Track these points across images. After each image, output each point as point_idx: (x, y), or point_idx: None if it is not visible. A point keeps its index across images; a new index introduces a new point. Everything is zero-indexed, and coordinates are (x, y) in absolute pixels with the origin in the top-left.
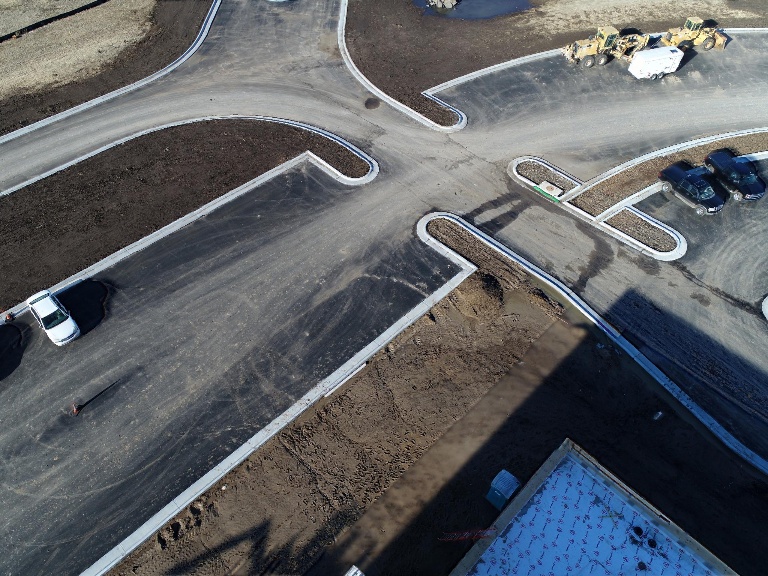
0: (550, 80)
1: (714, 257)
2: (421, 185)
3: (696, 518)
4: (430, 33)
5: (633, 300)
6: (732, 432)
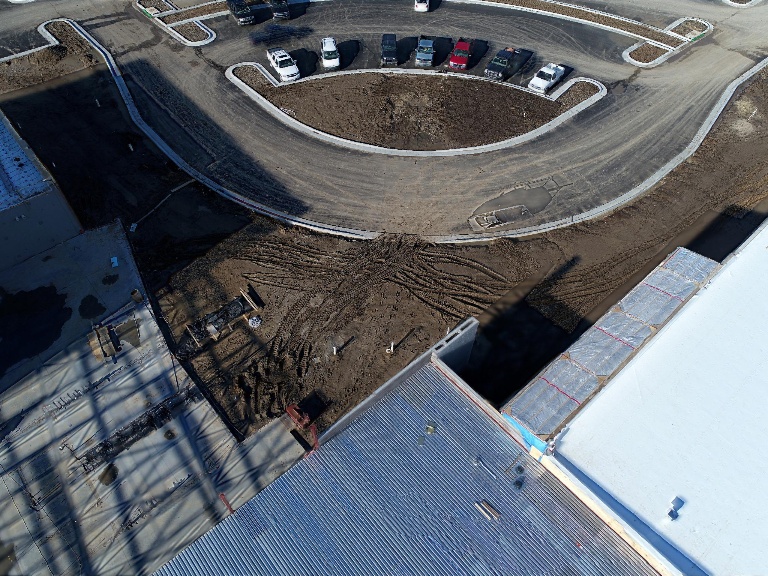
0: None
1: (226, 46)
2: (64, 5)
3: (77, 142)
4: None
5: (148, 62)
6: (142, 115)
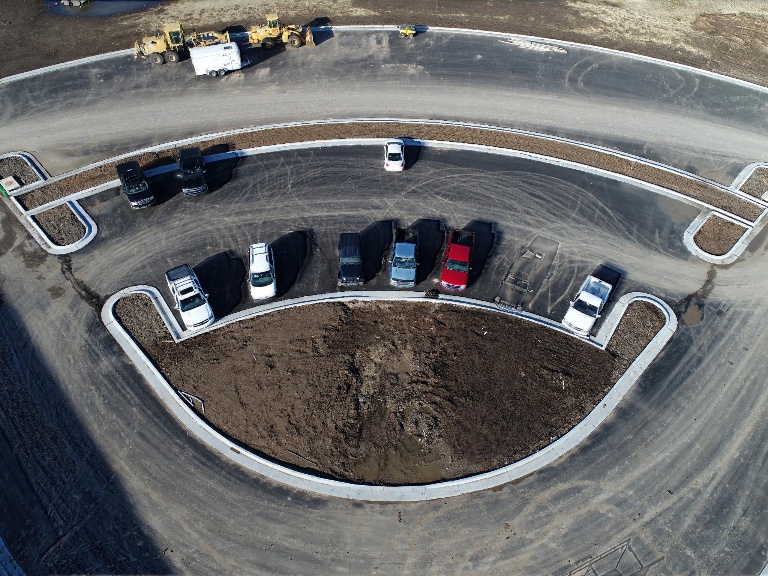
0: (111, 77)
1: (109, 251)
2: None
3: None
4: (31, 30)
5: None
6: None
